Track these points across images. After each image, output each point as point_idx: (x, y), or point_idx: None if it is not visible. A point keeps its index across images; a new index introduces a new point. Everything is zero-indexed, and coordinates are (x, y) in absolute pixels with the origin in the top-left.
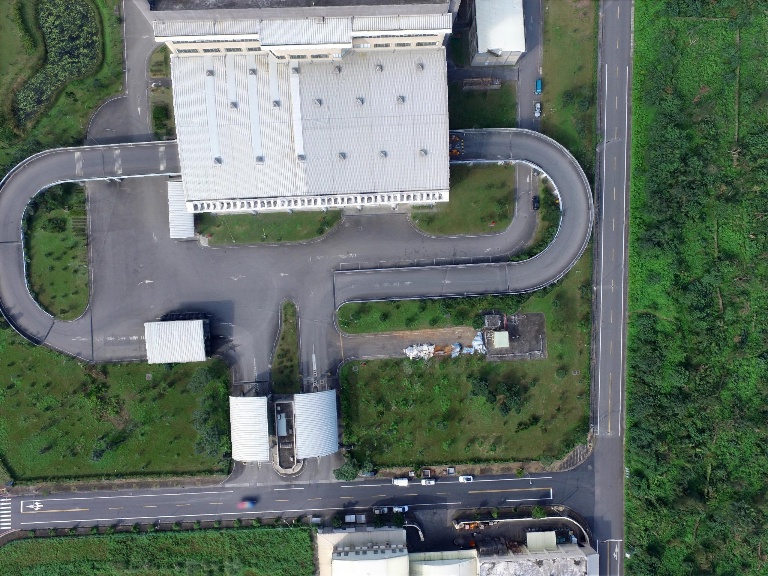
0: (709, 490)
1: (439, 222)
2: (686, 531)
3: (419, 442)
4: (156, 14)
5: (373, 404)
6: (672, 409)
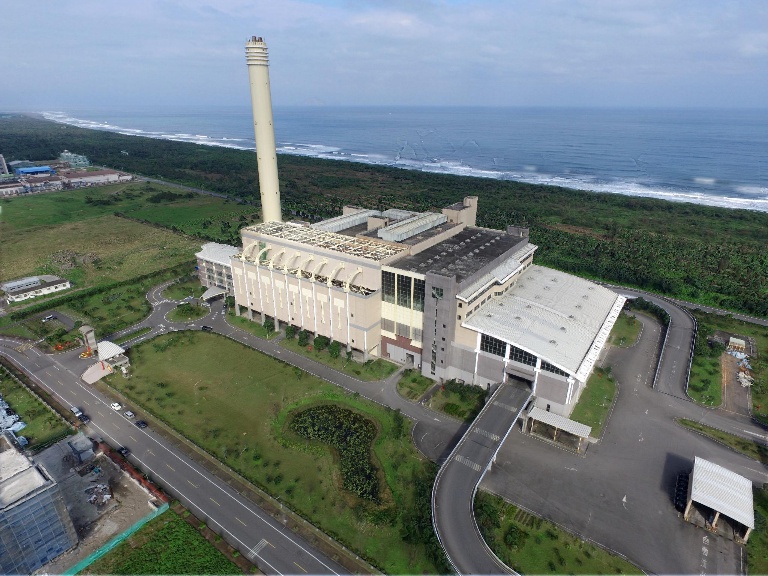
0: None
1: None
2: None
3: None
4: (459, 286)
5: None
6: None
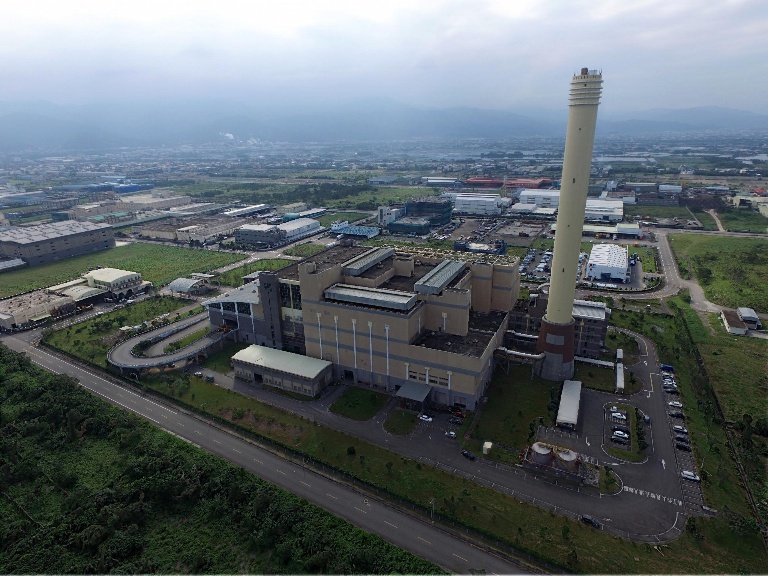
0: None
1: None
2: None
3: None
4: None
5: None
6: None
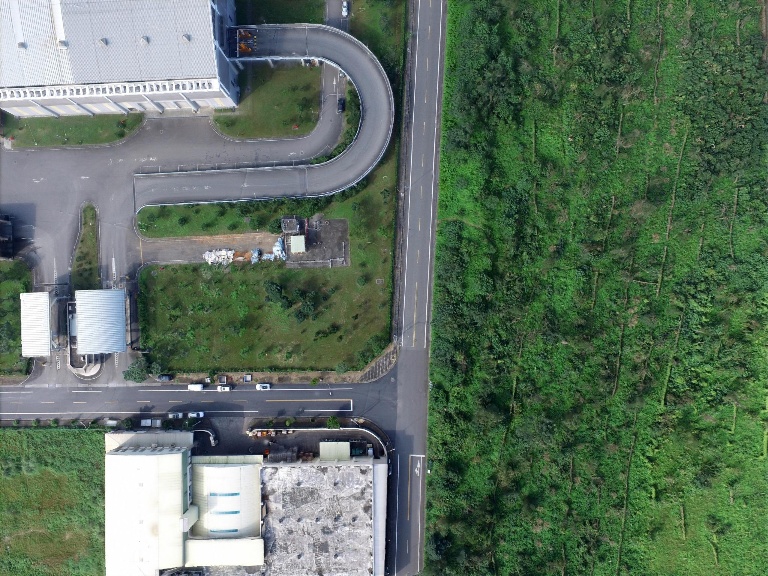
0: (514, 405)
1: (241, 125)
2: (493, 449)
3: (216, 348)
4: None
5: (168, 308)
6: (470, 317)
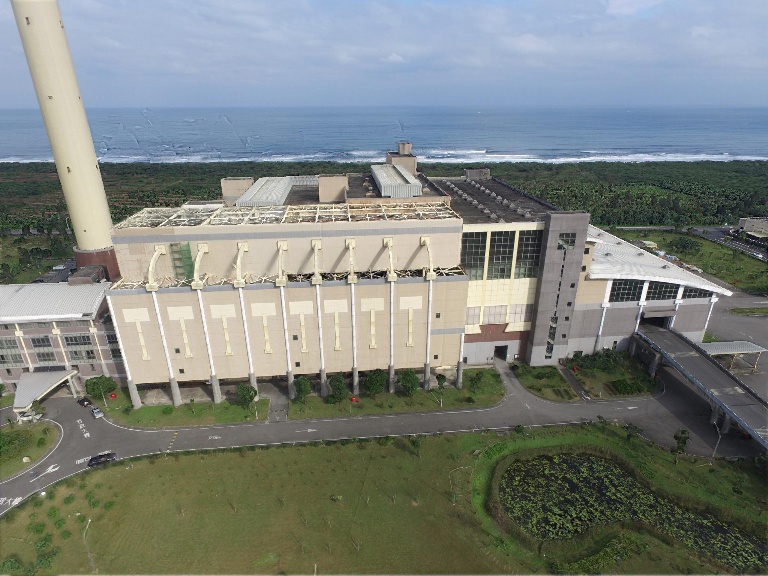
0: None
1: None
2: None
3: (760, 267)
4: None
5: None
6: None
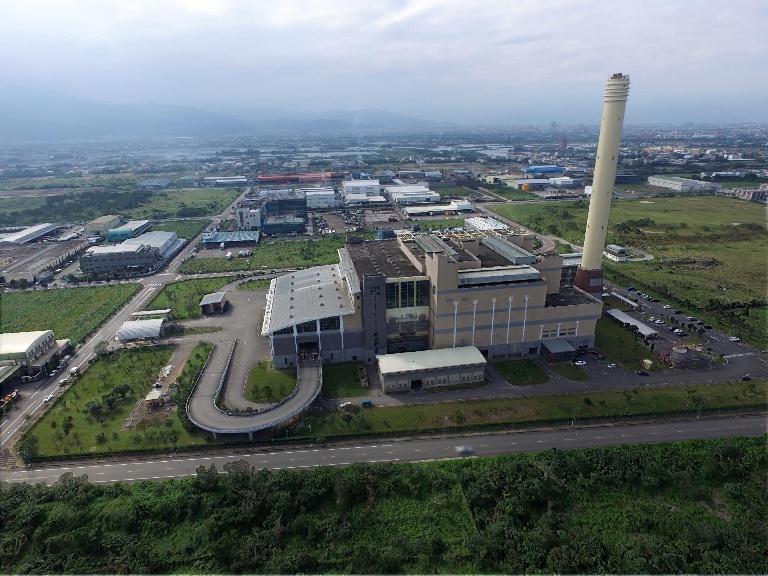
0: None
1: None
2: None
3: (97, 376)
4: None
5: None
6: None
